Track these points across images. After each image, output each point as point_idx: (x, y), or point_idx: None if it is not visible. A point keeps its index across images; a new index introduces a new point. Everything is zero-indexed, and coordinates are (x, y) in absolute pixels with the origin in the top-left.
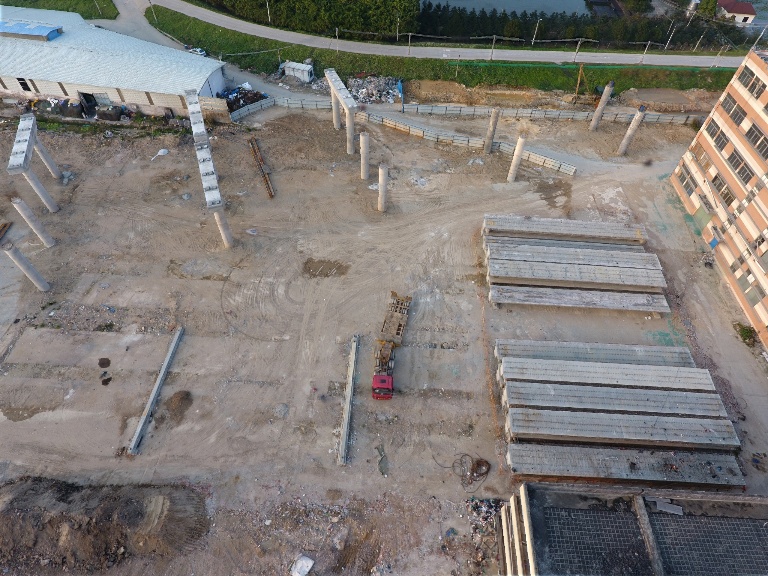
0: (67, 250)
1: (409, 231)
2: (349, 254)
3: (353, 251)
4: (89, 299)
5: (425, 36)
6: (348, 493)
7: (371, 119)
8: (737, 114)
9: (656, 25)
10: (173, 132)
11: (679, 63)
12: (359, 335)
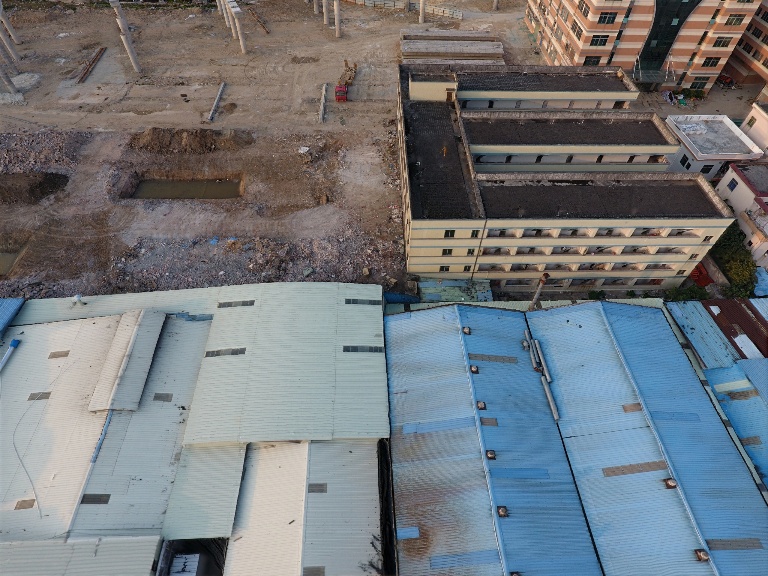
0: (145, 57)
1: (356, 45)
2: (319, 54)
3: (321, 53)
4: (166, 75)
5: None
6: (325, 131)
7: None
8: None
9: None
10: (196, 6)
11: None
12: (327, 82)
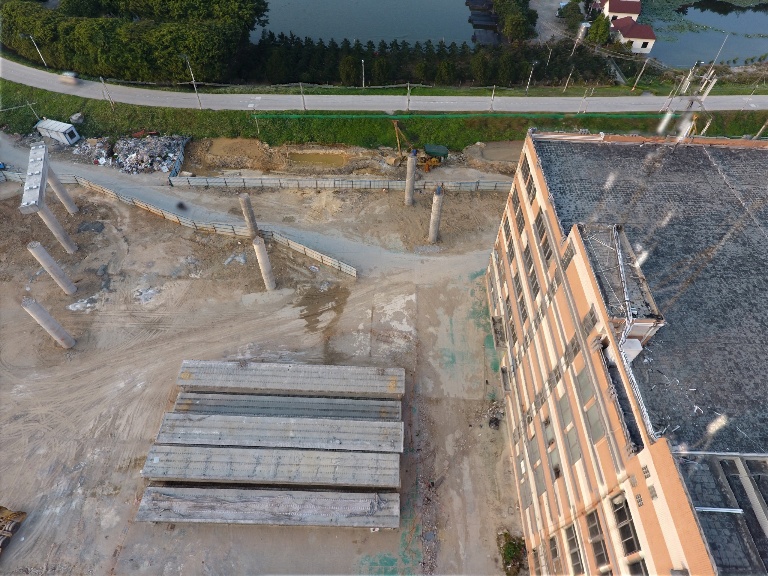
0: None
1: (90, 381)
2: None
3: None
4: None
5: (214, 85)
6: None
7: (121, 199)
8: (520, 219)
9: (536, 55)
10: None
11: (541, 108)
12: None
